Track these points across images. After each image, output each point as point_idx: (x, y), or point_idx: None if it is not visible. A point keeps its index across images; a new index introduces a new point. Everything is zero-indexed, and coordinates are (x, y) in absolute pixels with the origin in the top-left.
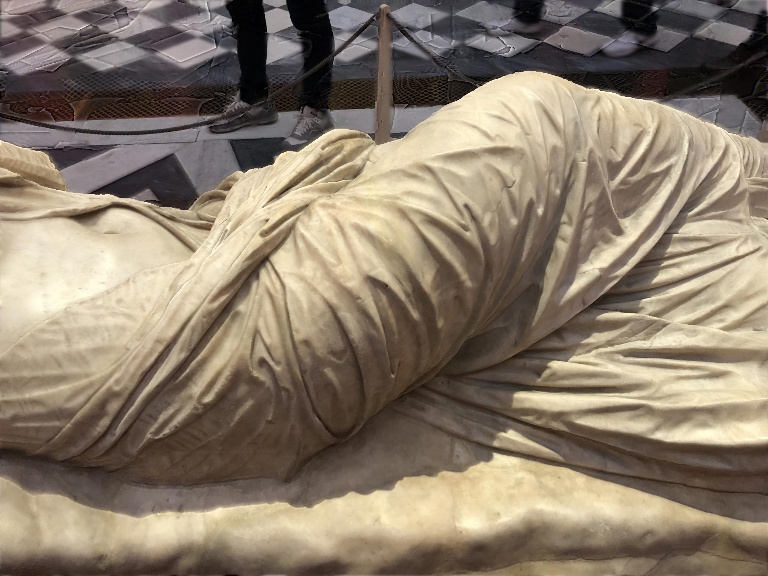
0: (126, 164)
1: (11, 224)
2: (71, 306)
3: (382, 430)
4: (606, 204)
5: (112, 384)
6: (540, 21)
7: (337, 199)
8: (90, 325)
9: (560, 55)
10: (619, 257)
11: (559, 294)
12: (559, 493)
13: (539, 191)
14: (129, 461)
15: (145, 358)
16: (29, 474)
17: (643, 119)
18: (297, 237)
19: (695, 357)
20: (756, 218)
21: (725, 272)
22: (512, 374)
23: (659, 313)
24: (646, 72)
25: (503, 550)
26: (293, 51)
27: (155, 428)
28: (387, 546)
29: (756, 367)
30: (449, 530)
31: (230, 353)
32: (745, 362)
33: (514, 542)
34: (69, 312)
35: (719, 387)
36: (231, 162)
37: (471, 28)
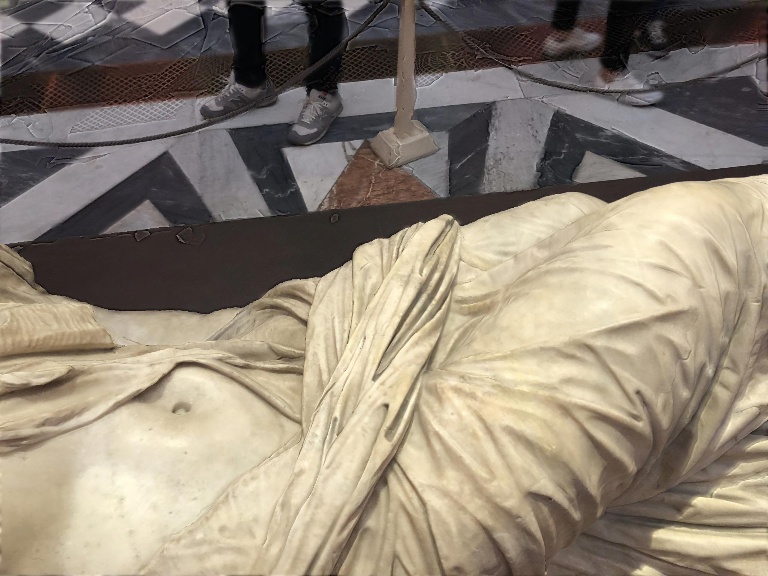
0: (116, 168)
1: (71, 436)
2: (168, 547)
3: None
4: None
5: None
6: None
7: (475, 386)
8: (195, 570)
9: None
10: None
11: (714, 439)
12: None
13: (712, 351)
14: None
15: None
16: None
17: None
18: (430, 435)
19: None
20: None
21: None
22: (647, 509)
23: None
24: (671, 9)
25: None
26: (291, 23)
27: None
28: None
29: None
30: None
31: None
32: None
33: None
34: (167, 556)
35: None
36: (234, 159)
37: None
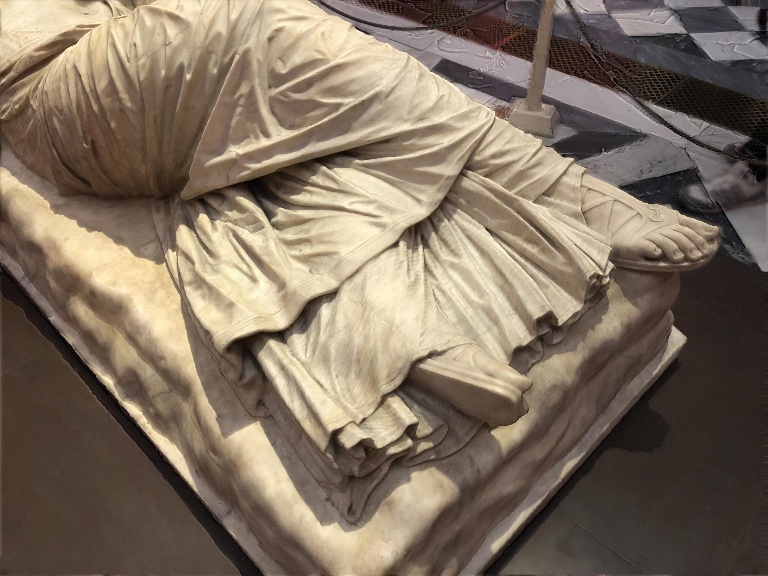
0: None
1: None
2: (8, 30)
3: (130, 207)
4: (256, 102)
5: None
6: None
7: None
8: (5, 42)
9: None
10: (252, 152)
11: (208, 158)
12: (154, 301)
13: (192, 60)
14: None
15: (1, 67)
16: None
17: (338, 52)
18: None
19: (256, 260)
20: (474, 222)
21: (328, 214)
22: (194, 214)
23: (284, 225)
24: None
25: (105, 307)
26: None
27: (1, 112)
28: (58, 255)
29: (275, 291)
30: (88, 272)
31: None
32: (273, 283)
33: (111, 307)
34: (5, 32)
35: (245, 287)
36: None
37: None
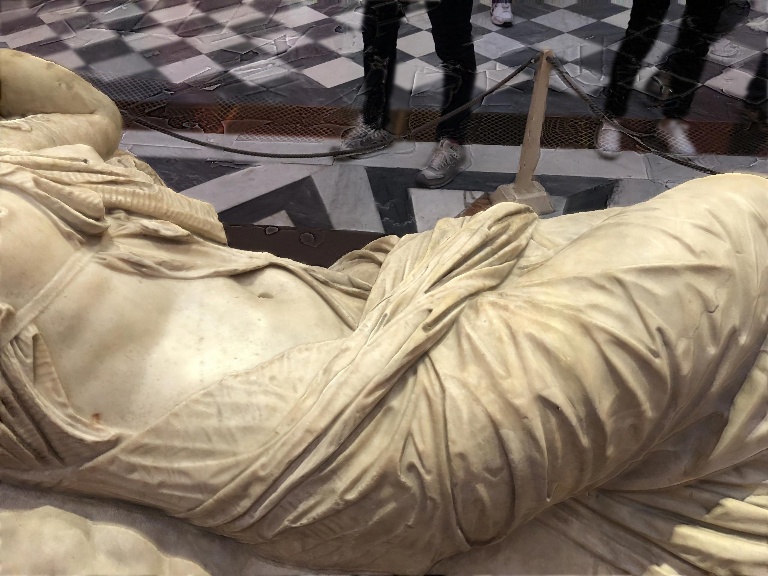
0: (265, 182)
1: (177, 283)
2: (226, 378)
3: (518, 538)
4: None
5: (258, 468)
6: (700, 60)
7: (510, 300)
8: (243, 401)
9: (722, 101)
10: None
11: (746, 428)
12: None
13: (743, 317)
14: (262, 542)
15: (294, 447)
16: (165, 534)
17: None
18: (462, 336)
19: None
20: None
21: None
22: (674, 502)
23: None
24: None
25: None
26: (440, 83)
27: (293, 516)
28: None
29: None
30: None
31: (378, 451)
32: None
33: None
34: (224, 385)
35: None
36: (365, 190)
37: (623, 64)
